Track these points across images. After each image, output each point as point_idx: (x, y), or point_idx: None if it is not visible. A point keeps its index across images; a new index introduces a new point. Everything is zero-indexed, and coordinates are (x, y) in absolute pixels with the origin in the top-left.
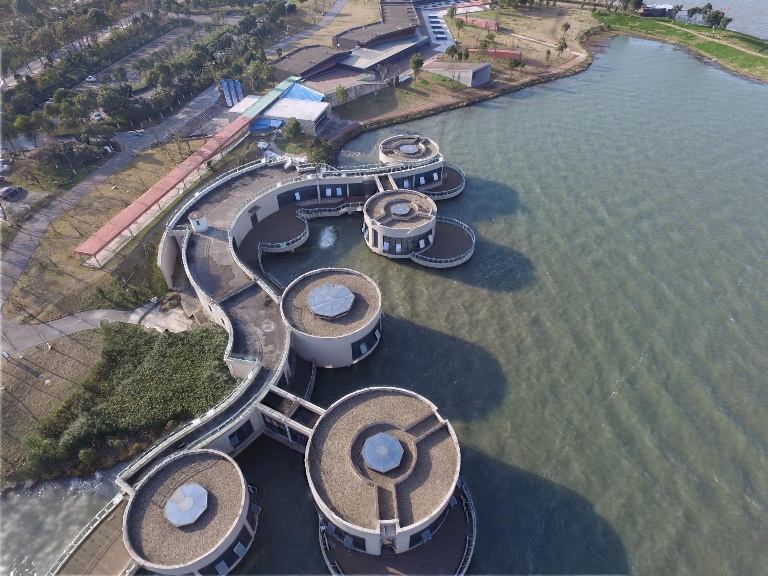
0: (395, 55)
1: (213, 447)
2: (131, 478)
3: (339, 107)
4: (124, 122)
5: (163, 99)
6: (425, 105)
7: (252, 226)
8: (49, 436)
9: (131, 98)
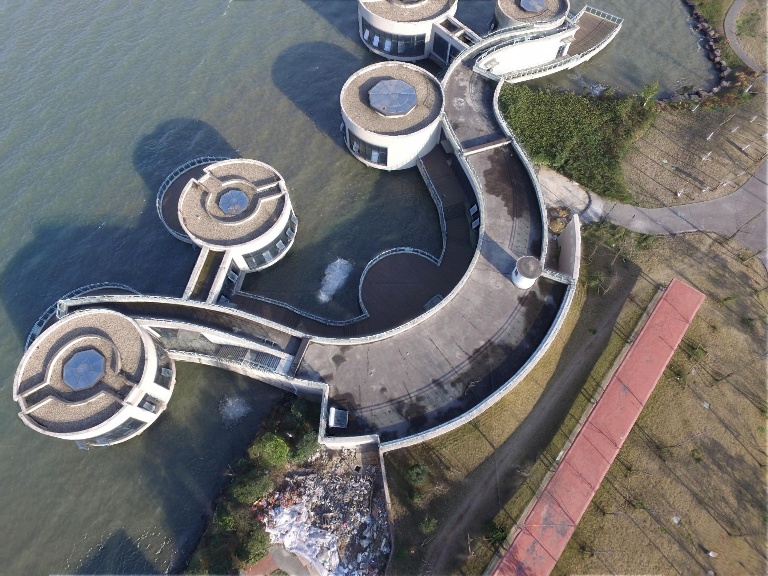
0: None
1: None
2: None
3: None
4: None
5: None
6: None
7: None
8: None
9: None
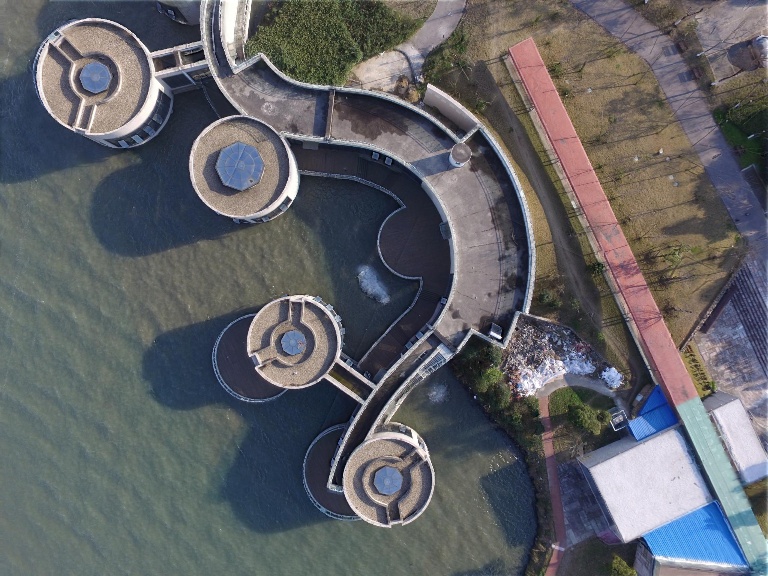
0: None
1: None
2: None
3: None
4: None
5: None
6: None
7: None
8: None
9: None
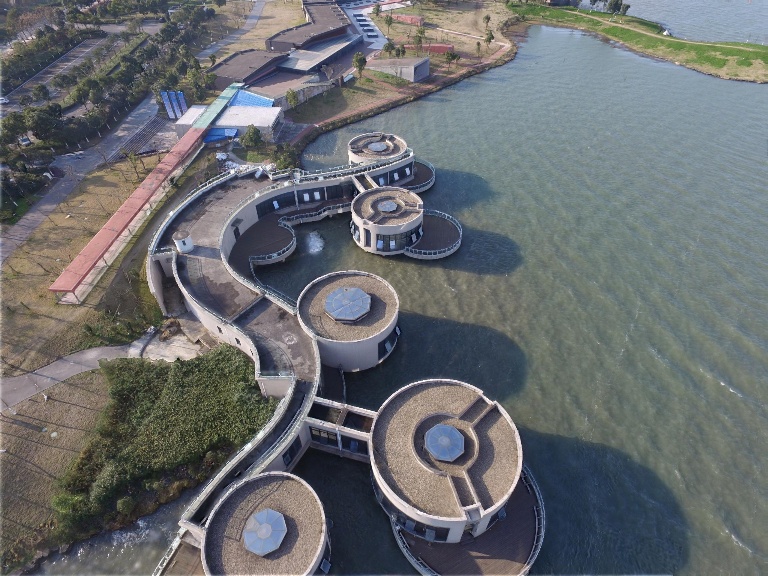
0: (333, 55)
1: (270, 469)
2: (194, 517)
3: (290, 111)
4: (58, 145)
5: (98, 116)
6: (374, 103)
7: (235, 240)
8: (76, 492)
9: (61, 118)
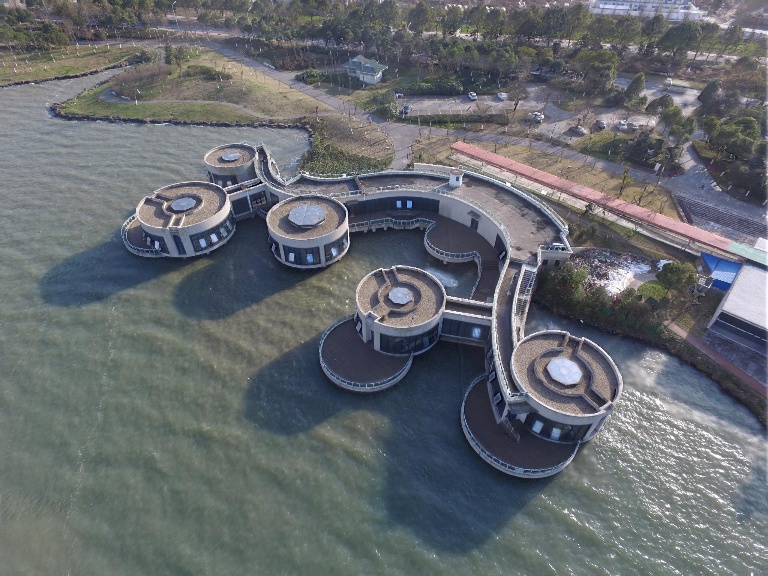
0: None
1: None
2: None
3: None
4: None
5: None
6: None
7: (471, 226)
8: None
9: None
